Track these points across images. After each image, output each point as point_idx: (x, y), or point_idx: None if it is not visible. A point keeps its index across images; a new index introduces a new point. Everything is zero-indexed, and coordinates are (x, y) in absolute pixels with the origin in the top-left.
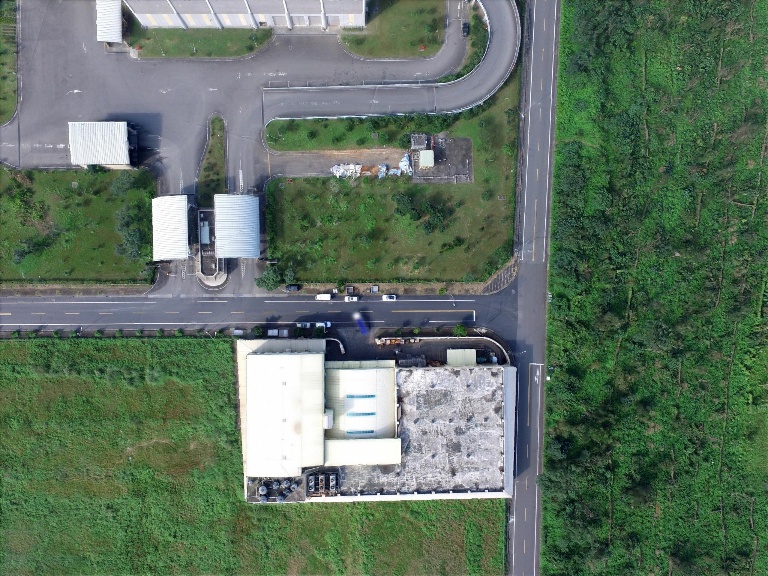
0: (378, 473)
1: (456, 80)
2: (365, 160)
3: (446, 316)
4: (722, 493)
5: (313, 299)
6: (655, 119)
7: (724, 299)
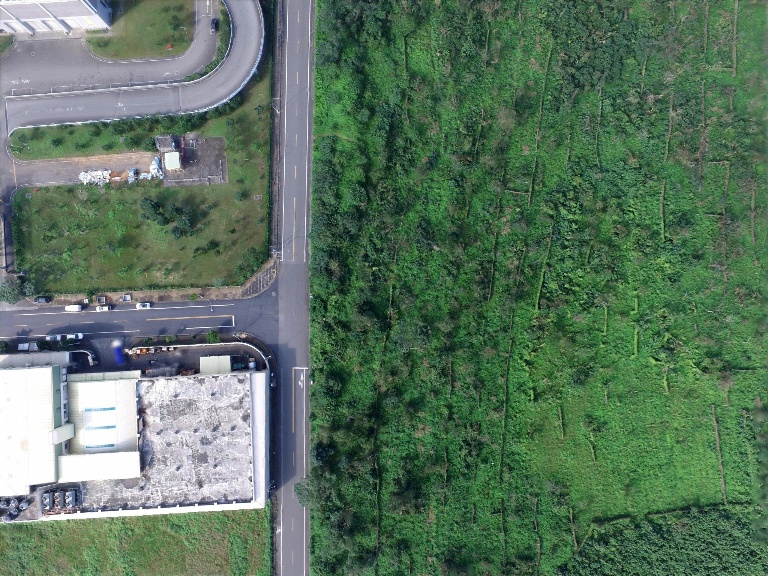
0: (121, 488)
1: (200, 78)
2: (114, 165)
3: (204, 322)
4: (503, 495)
5: (64, 311)
6: (417, 108)
7: (498, 292)
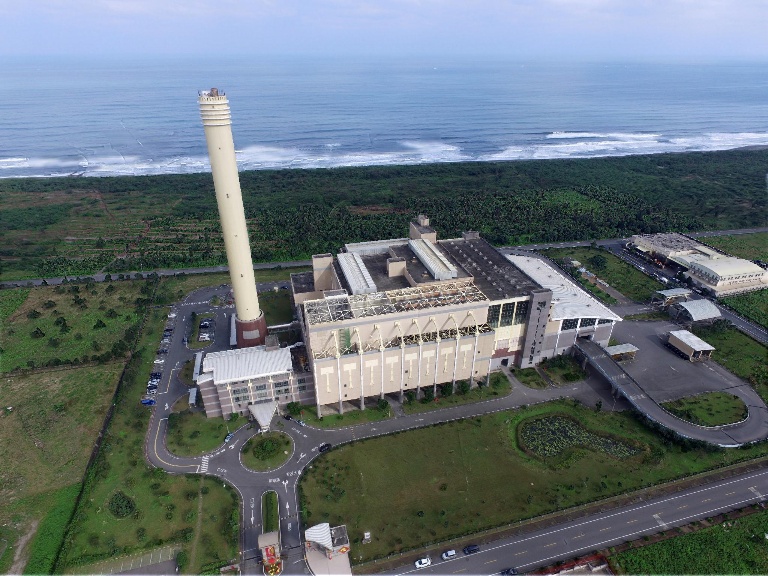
0: None
1: None
2: None
3: None
4: None
5: None
6: None
7: None
